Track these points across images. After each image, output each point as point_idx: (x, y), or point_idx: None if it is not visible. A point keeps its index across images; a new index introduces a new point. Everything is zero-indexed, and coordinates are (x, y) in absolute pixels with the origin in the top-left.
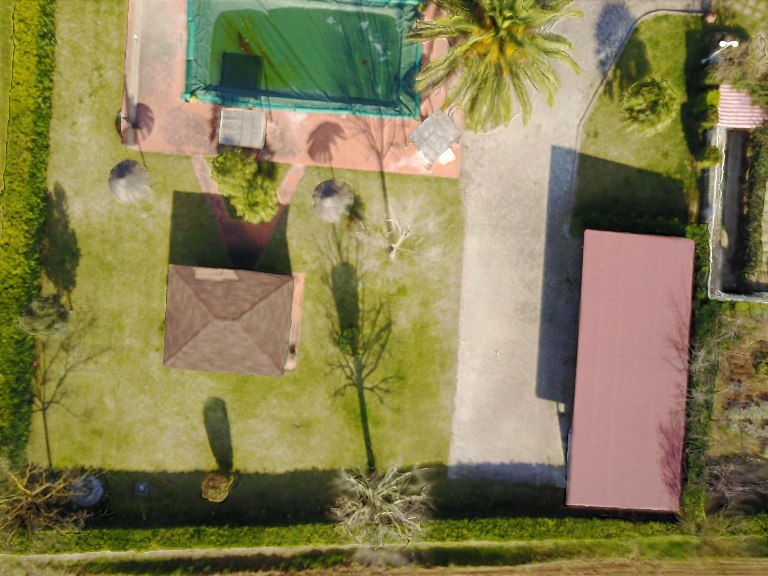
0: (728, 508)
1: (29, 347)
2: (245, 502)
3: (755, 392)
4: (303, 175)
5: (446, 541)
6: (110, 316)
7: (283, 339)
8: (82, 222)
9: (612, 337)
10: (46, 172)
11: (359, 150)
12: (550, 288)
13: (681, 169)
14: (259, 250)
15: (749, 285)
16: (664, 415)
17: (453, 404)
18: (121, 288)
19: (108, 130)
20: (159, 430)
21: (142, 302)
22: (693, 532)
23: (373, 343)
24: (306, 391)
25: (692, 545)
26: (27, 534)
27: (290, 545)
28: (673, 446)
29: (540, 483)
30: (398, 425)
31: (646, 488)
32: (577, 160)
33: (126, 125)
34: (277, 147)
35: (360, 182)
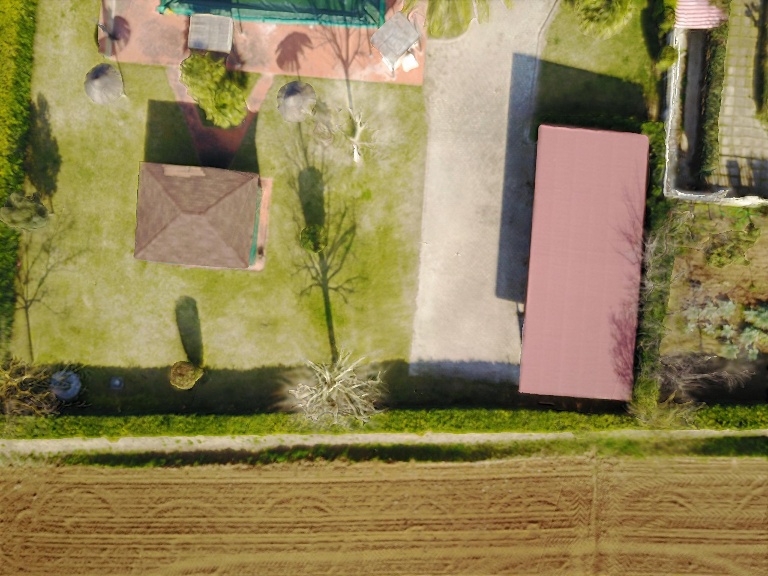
0: (683, 402)
1: (13, 247)
2: (215, 397)
3: (714, 293)
4: (271, 84)
5: (405, 431)
6: (88, 219)
7: (247, 233)
8: (63, 130)
9: (565, 230)
10: (30, 83)
11: (325, 59)
12: (511, 192)
13: (641, 74)
14: (229, 156)
15: (709, 188)
16: (617, 307)
17: (415, 304)
18: (99, 192)
19: (87, 42)
20: (134, 327)
21: (118, 205)
22: (644, 420)
23: (338, 245)
24: (273, 291)
25: (651, 445)
26: (8, 418)
27: (255, 433)
28: (626, 337)
29: (500, 381)
30: (362, 324)
31: (599, 378)
32: (538, 67)
33: (103, 34)
34: (247, 57)
35: (326, 90)
